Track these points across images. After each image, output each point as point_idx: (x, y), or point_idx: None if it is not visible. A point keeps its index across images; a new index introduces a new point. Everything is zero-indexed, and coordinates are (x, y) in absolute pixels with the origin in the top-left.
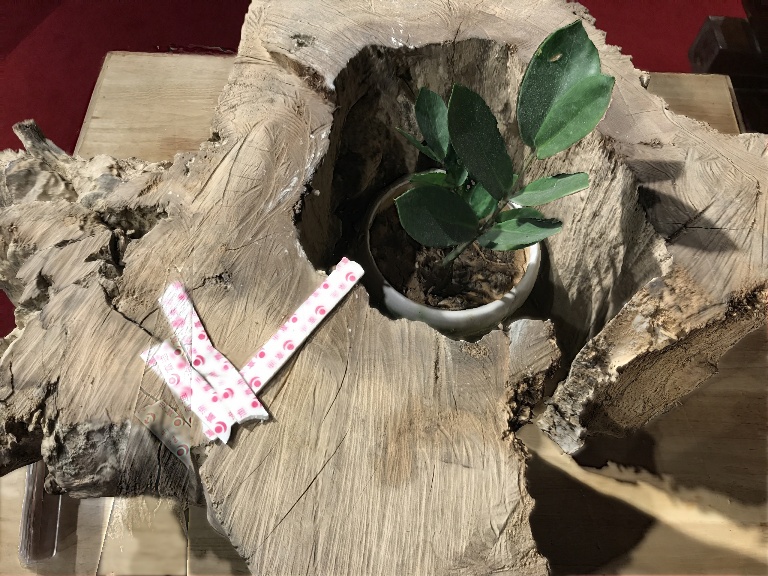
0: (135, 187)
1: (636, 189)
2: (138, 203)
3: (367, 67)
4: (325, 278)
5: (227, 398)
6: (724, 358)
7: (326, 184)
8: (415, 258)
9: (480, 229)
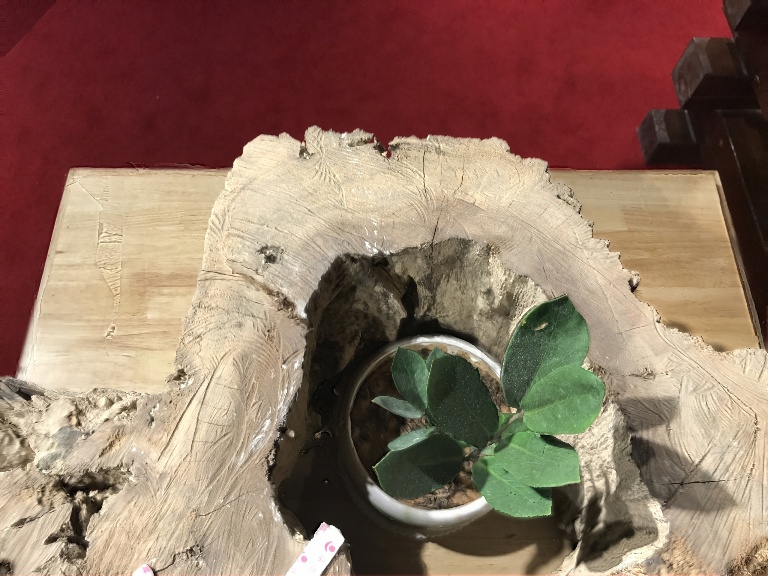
0: (96, 446)
1: (629, 436)
2: (100, 465)
3: (340, 271)
4: (303, 546)
5: None
6: None
7: (302, 402)
8: (399, 435)
9: (466, 456)
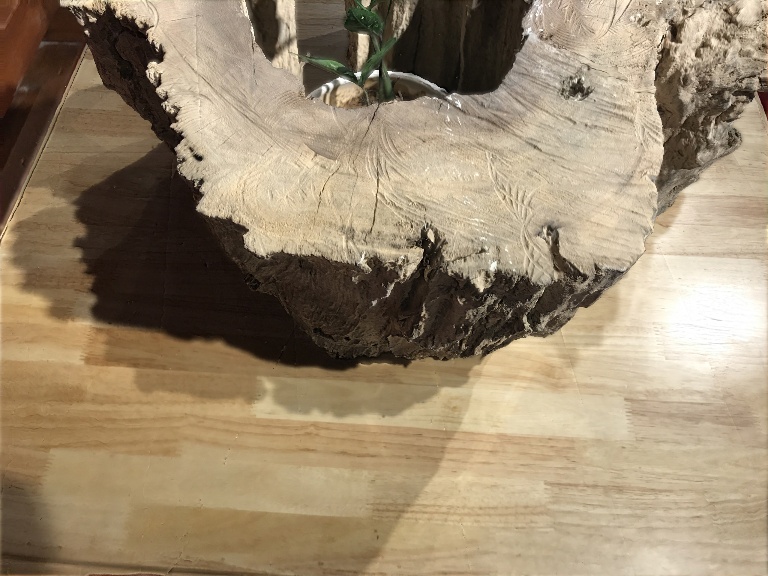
0: None
1: None
2: None
3: None
4: None
5: None
6: (116, 160)
7: None
8: None
9: None
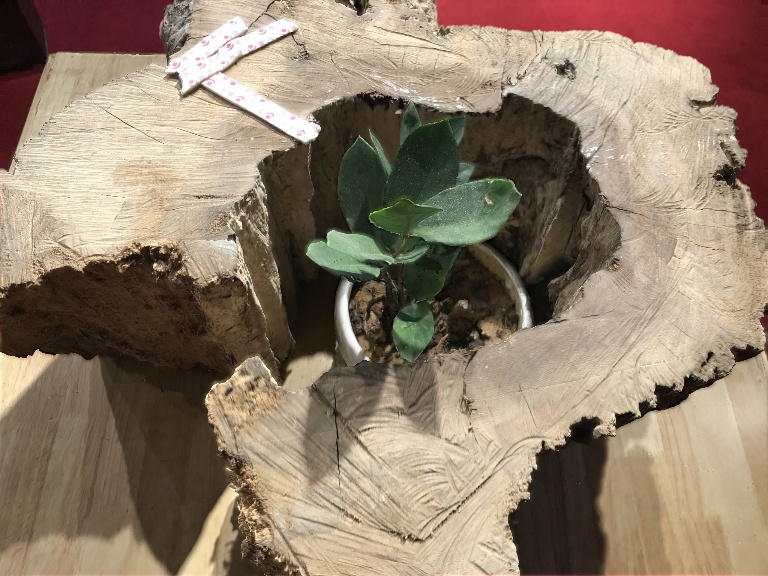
0: None
1: None
2: None
3: (563, 141)
4: None
5: (198, 65)
6: None
7: None
8: None
9: None
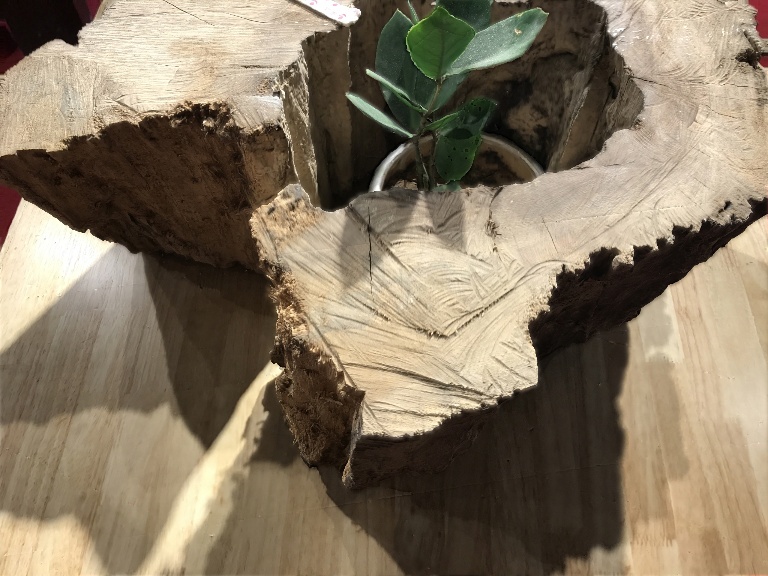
0: None
1: None
2: None
3: (591, 28)
4: None
5: None
6: None
7: None
8: None
9: None
